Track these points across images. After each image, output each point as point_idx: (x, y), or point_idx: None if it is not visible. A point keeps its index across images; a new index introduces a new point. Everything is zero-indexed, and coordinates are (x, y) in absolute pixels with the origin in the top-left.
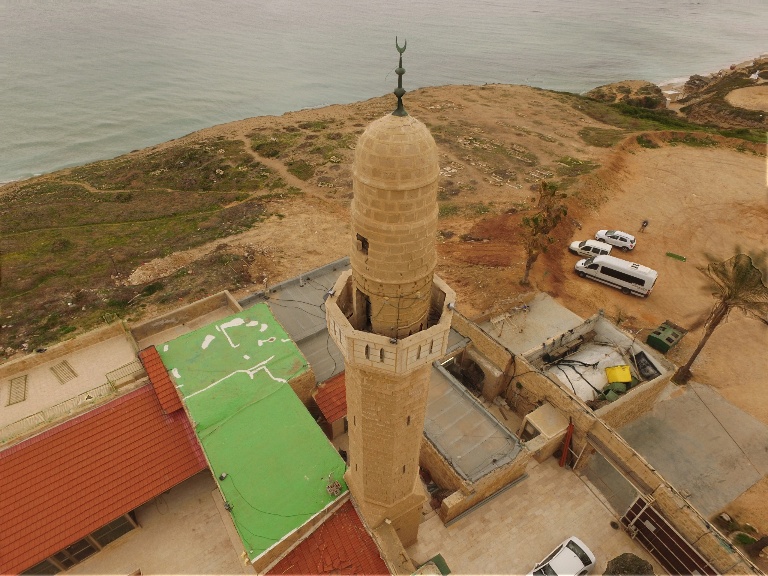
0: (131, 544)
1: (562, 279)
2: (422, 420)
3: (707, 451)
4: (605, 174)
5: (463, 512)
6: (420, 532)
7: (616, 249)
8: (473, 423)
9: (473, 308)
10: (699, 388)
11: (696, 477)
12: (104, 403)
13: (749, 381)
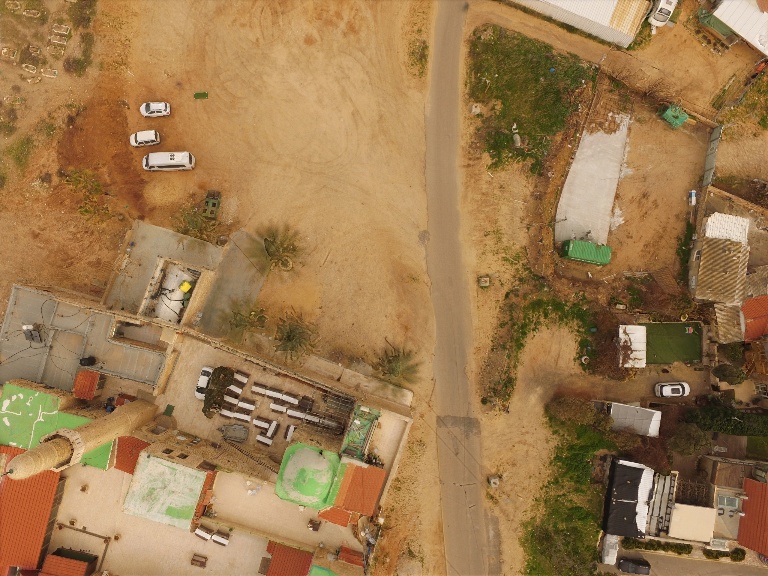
0: (71, 483)
1: (141, 190)
2: (105, 432)
3: (243, 281)
4: (109, 3)
5: (166, 385)
6: (157, 403)
7: (161, 118)
8: (143, 358)
9: (109, 251)
10: (235, 237)
11: (240, 301)
12: (2, 473)
13: (259, 206)
